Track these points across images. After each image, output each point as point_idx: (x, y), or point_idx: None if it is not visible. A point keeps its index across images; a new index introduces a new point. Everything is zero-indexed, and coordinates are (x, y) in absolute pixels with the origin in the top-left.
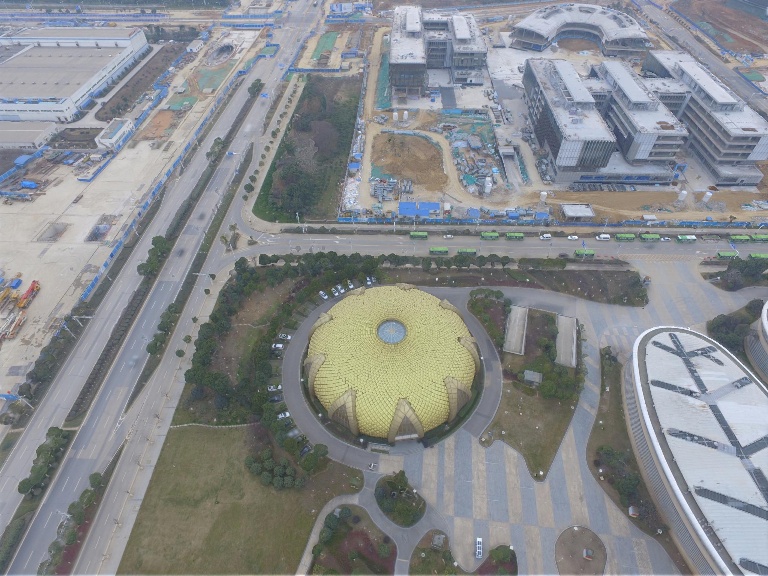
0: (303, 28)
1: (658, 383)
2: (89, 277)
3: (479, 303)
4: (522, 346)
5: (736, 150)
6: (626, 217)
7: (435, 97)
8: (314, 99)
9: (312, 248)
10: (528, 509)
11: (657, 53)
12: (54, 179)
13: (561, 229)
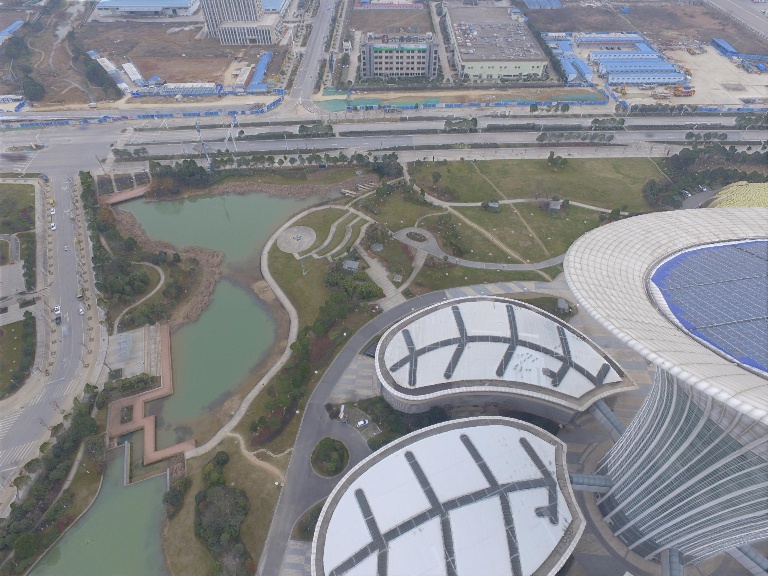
0: None
1: None
2: None
3: None
4: None
5: None
6: None
7: None
8: None
9: None
10: None
11: None
12: None
13: None
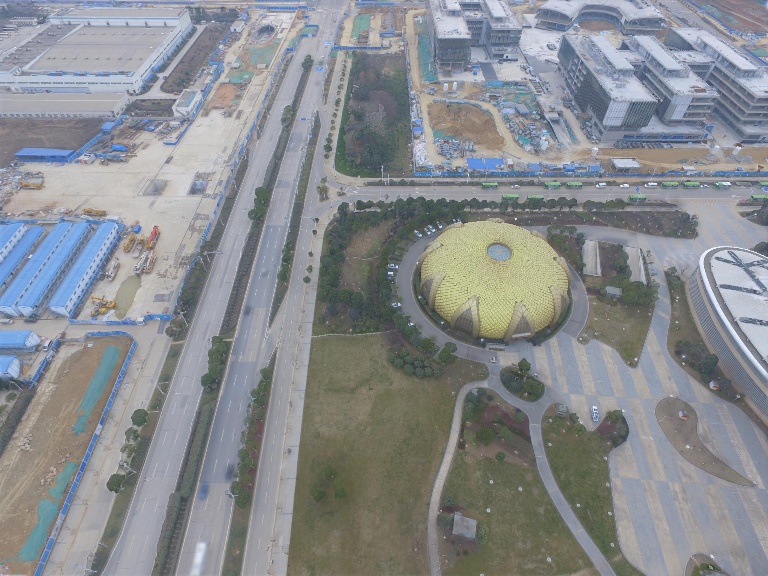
0: (336, 10)
1: (726, 286)
2: (202, 223)
3: (555, 238)
4: (597, 271)
5: (759, 111)
6: (668, 169)
7: (476, 71)
8: (369, 72)
9: (400, 196)
10: (628, 387)
11: (678, 30)
12: (140, 143)
13: (613, 179)
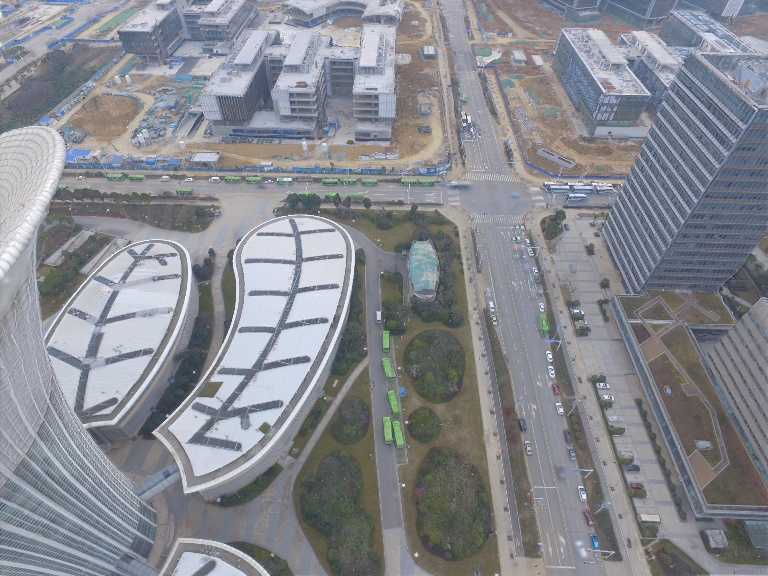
0: (111, 4)
1: (97, 277)
2: None
3: (55, 228)
4: None
5: (365, 108)
6: (251, 164)
7: (176, 65)
8: (47, 63)
9: None
10: None
11: (368, 26)
12: None
13: (186, 173)
